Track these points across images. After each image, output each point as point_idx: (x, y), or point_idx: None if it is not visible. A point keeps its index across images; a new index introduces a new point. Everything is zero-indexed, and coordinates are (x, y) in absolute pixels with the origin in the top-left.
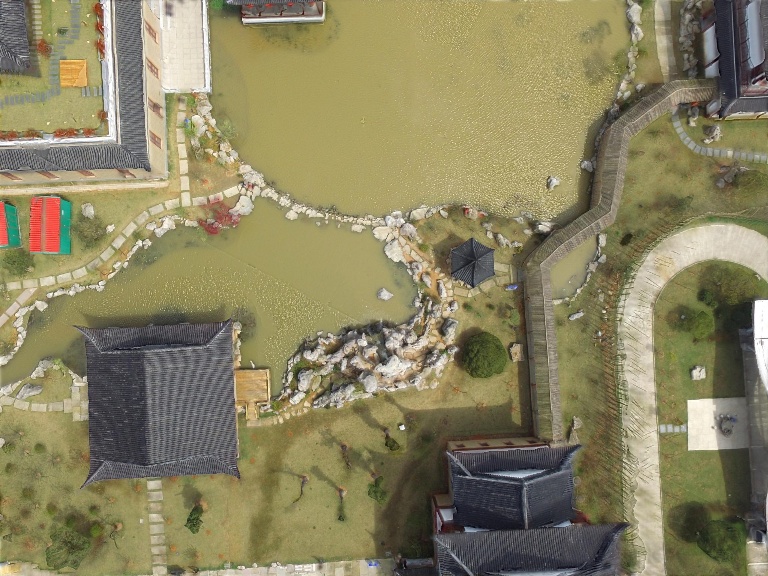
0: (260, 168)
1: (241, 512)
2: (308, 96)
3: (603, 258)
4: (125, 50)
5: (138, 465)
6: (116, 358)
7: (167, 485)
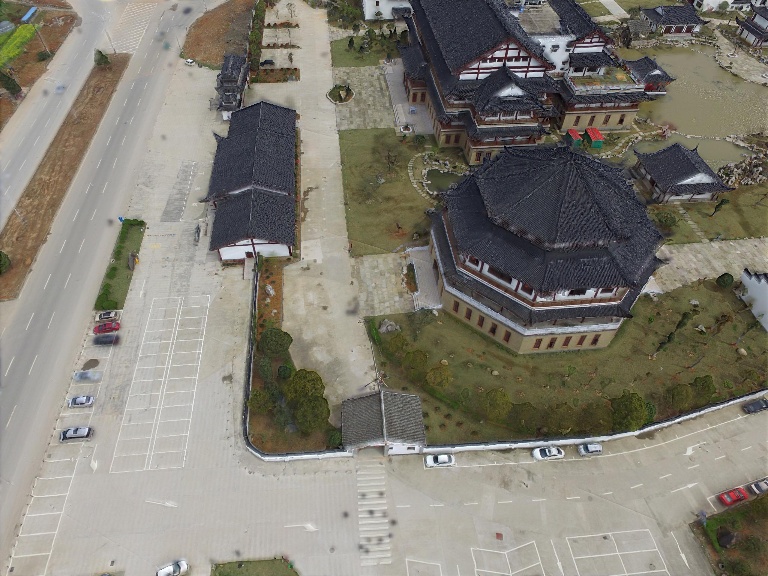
0: None
1: (732, 219)
2: None
3: None
4: None
5: (696, 175)
6: (660, 154)
7: (689, 211)
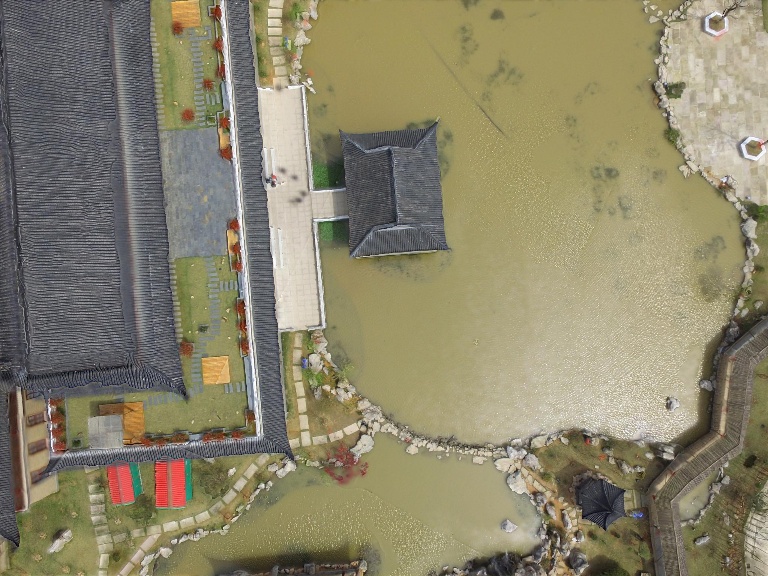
0: (377, 400)
1: None
2: (417, 315)
3: (726, 479)
4: (262, 335)
5: None
6: None
7: None
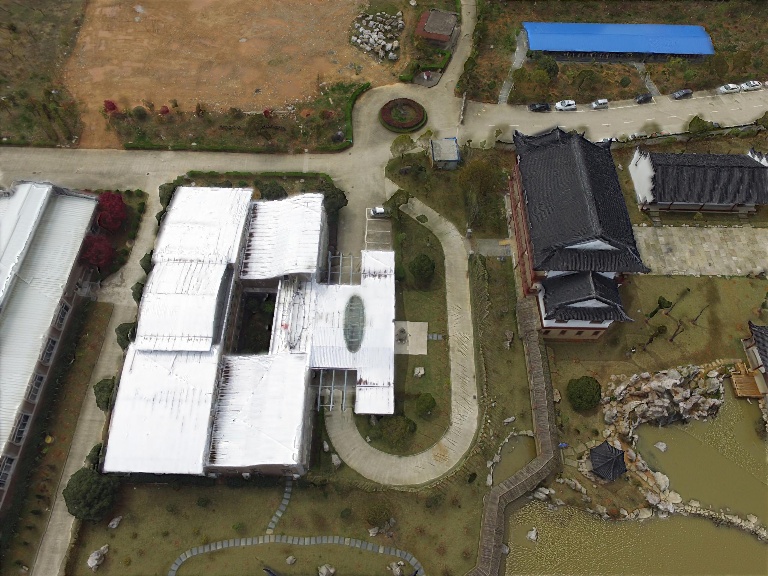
0: None
1: (729, 307)
2: None
3: (489, 465)
4: None
5: None
6: None
7: None
